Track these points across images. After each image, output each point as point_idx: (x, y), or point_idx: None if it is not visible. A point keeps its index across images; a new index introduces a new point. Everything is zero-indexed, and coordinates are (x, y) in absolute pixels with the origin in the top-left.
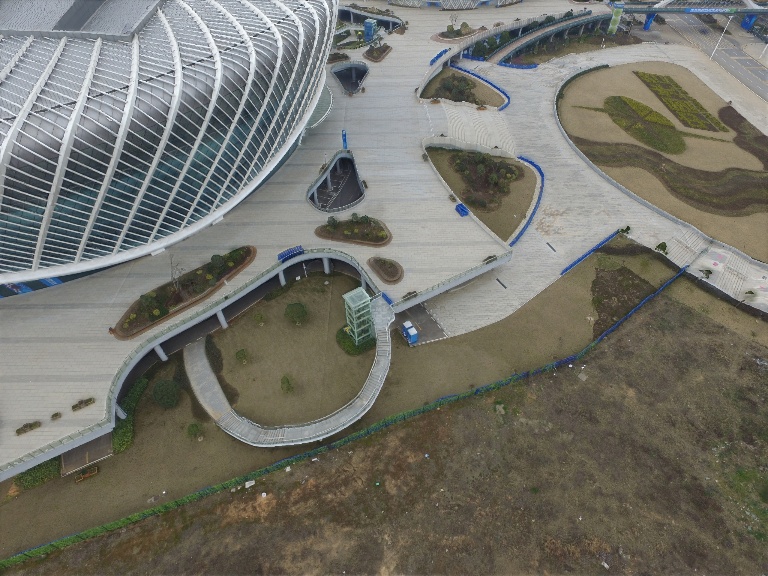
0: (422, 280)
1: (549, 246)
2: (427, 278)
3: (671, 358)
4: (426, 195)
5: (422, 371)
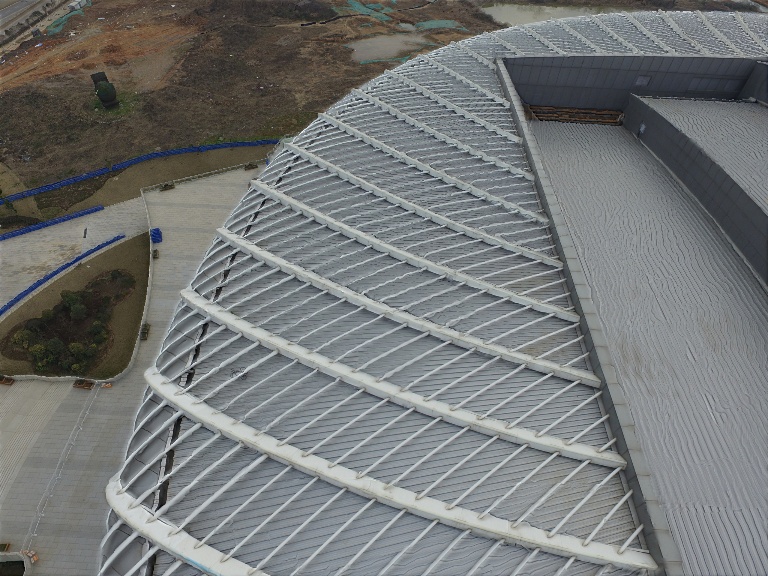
0: (236, 178)
1: (86, 234)
2: (231, 179)
3: (88, 155)
4: (184, 263)
5: (260, 162)
